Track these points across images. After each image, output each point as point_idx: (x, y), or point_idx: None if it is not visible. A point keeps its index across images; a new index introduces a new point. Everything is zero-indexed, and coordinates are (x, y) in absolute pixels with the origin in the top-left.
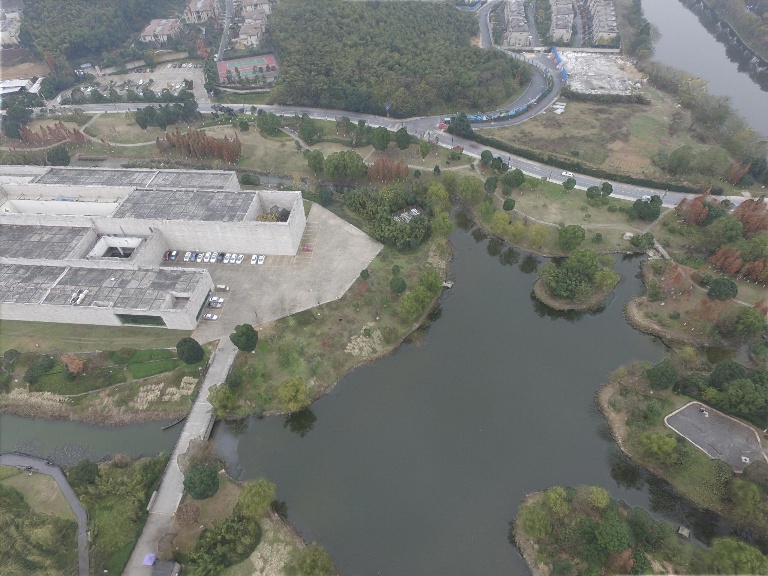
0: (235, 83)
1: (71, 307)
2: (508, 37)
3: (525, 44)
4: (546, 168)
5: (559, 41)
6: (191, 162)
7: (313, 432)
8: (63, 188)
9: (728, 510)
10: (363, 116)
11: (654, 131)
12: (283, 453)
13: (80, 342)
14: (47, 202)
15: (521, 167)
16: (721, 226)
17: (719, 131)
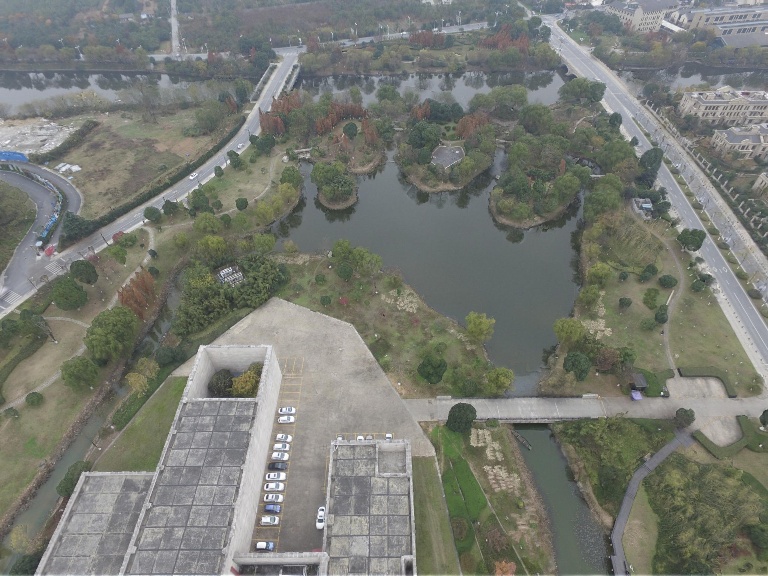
0: None
1: None
2: None
3: None
4: (177, 187)
5: None
6: None
7: None
8: None
9: (491, 156)
10: None
11: (144, 129)
12: None
13: None
14: None
15: None
16: (302, 115)
17: (161, 105)
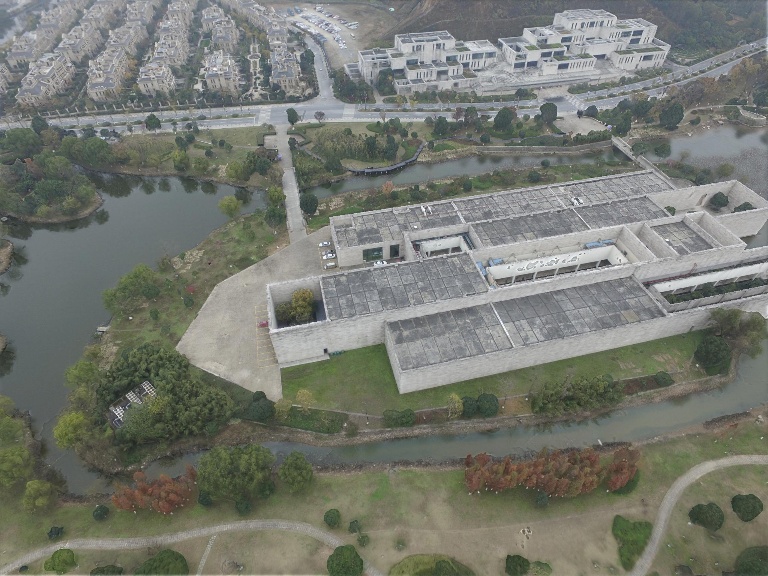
0: None
1: (423, 204)
2: None
3: None
4: None
5: None
6: None
7: None
8: None
9: None
10: None
11: None
12: None
13: None
14: (585, 271)
15: None
16: None
17: None
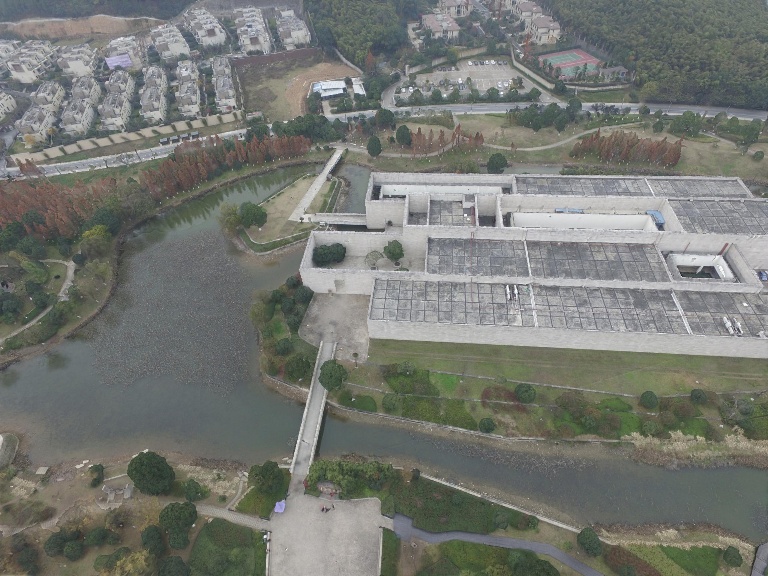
0: (586, 80)
1: (740, 339)
2: None
3: None
4: None
5: None
6: (615, 167)
7: None
8: (577, 199)
9: None
10: (762, 113)
11: None
12: None
13: (744, 378)
14: (559, 215)
15: None
16: None
17: None
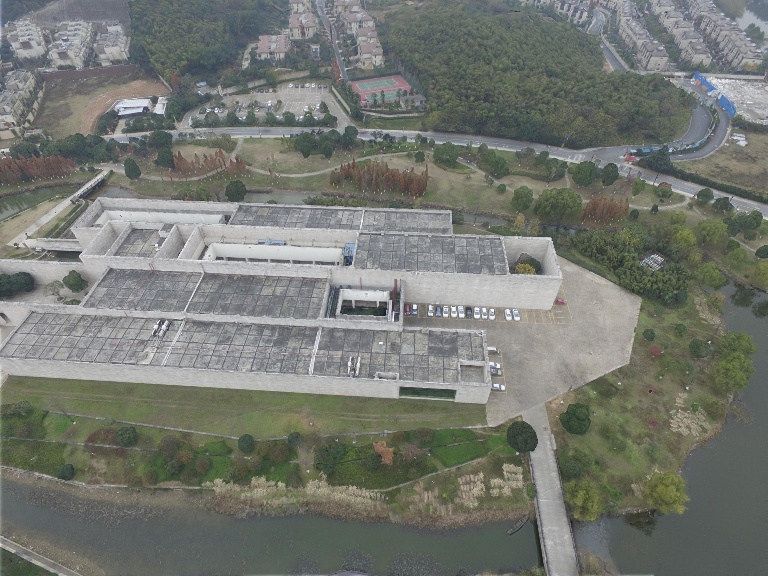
0: (382, 107)
1: (352, 379)
2: (644, 61)
3: (663, 69)
4: (765, 207)
5: (701, 67)
6: (369, 196)
7: (655, 528)
8: (275, 231)
9: None
10: (534, 145)
11: None
12: (668, 565)
13: (360, 419)
14: (256, 246)
15: (738, 206)
16: None
17: None
